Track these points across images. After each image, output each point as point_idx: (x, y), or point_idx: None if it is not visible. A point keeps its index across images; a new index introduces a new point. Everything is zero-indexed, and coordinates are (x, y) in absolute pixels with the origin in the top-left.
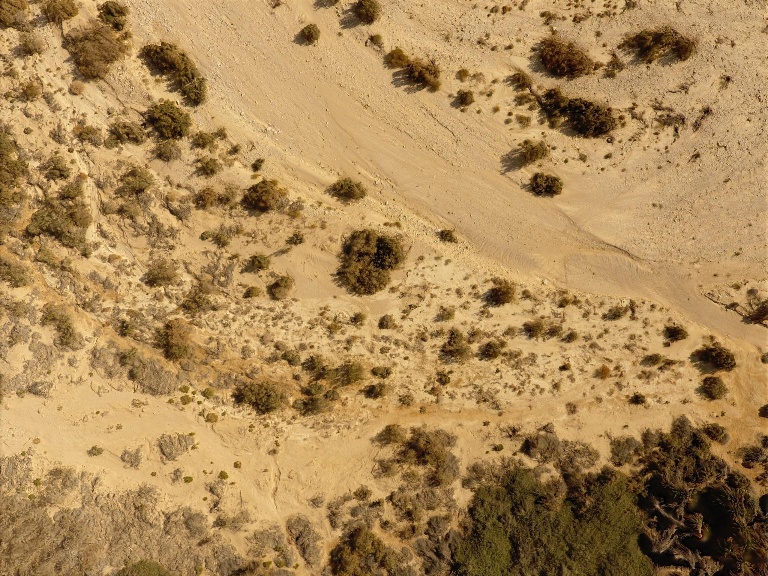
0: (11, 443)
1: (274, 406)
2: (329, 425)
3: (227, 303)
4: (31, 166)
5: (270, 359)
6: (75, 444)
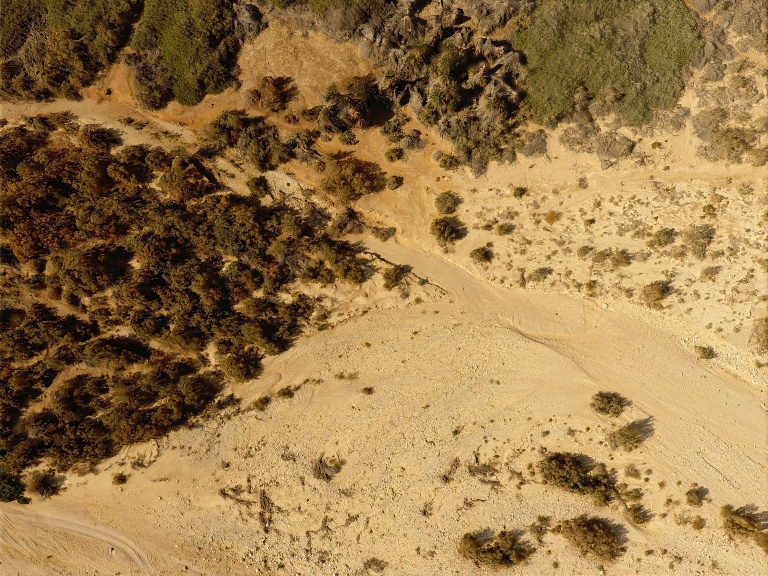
0: None
1: None
2: None
3: None
4: None
5: None
6: None
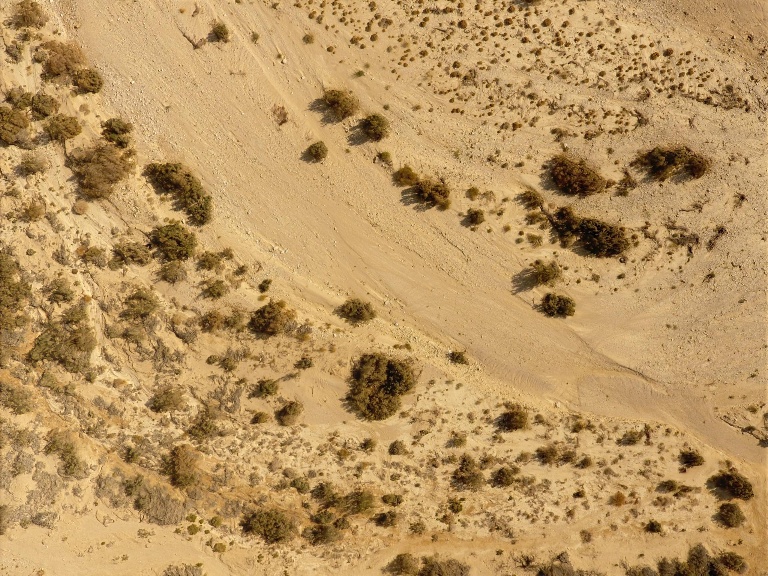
0: (15, 575)
1: (283, 536)
2: (339, 554)
3: (234, 429)
4: (34, 288)
5: (279, 487)
6: (80, 575)
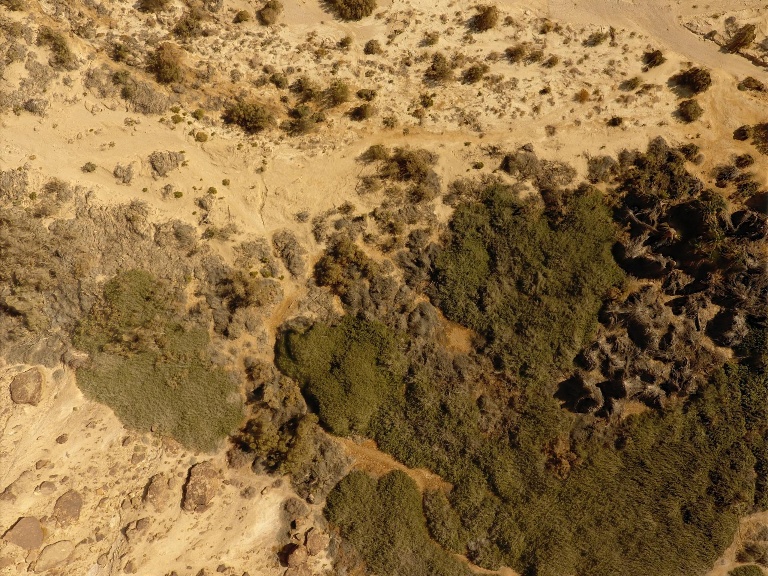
0: (8, 159)
1: (262, 126)
2: (315, 146)
3: (217, 29)
4: None
5: (258, 81)
6: (69, 161)
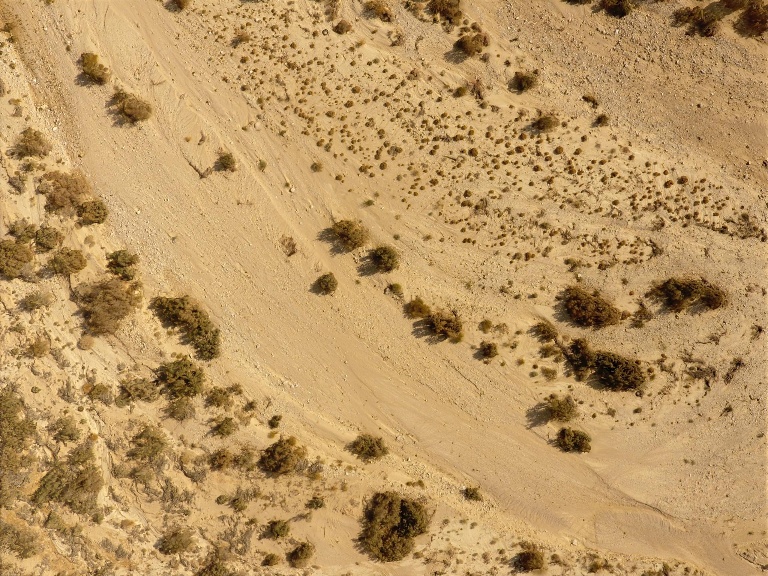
0: None
1: None
2: None
3: (245, 571)
4: (39, 426)
5: None
6: None
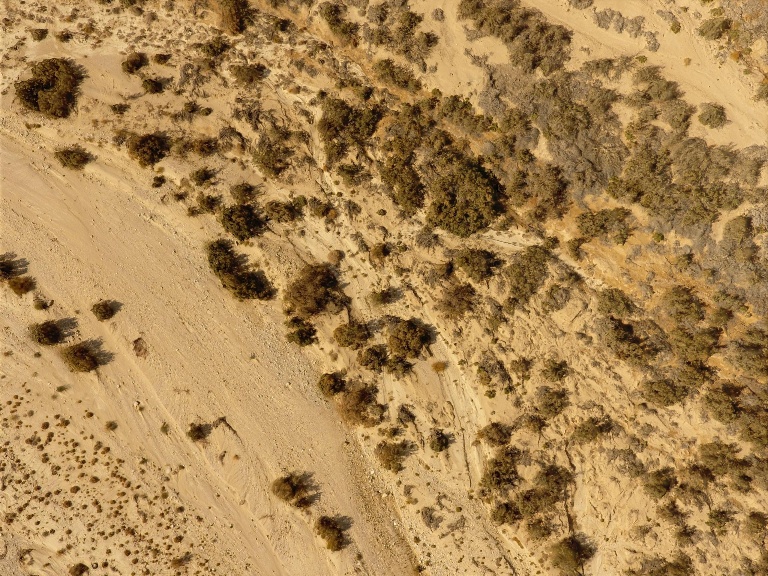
0: None
1: None
2: None
3: (187, 50)
4: (378, 179)
5: None
6: None
